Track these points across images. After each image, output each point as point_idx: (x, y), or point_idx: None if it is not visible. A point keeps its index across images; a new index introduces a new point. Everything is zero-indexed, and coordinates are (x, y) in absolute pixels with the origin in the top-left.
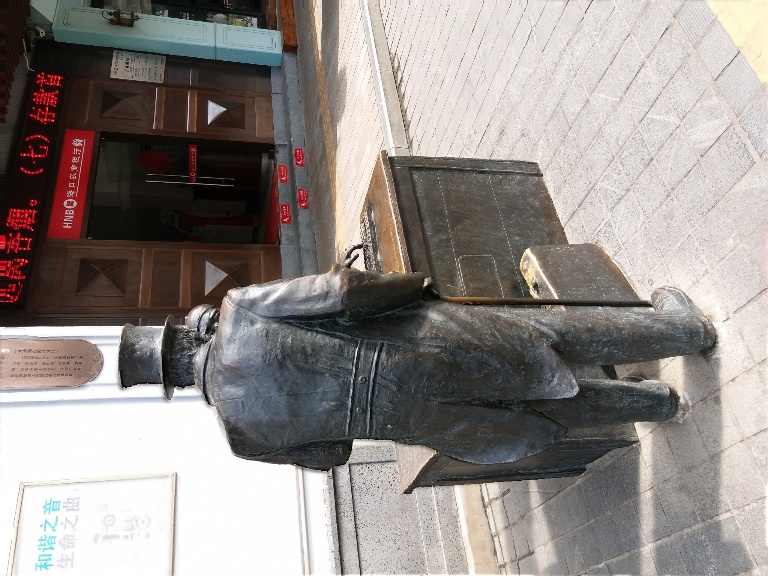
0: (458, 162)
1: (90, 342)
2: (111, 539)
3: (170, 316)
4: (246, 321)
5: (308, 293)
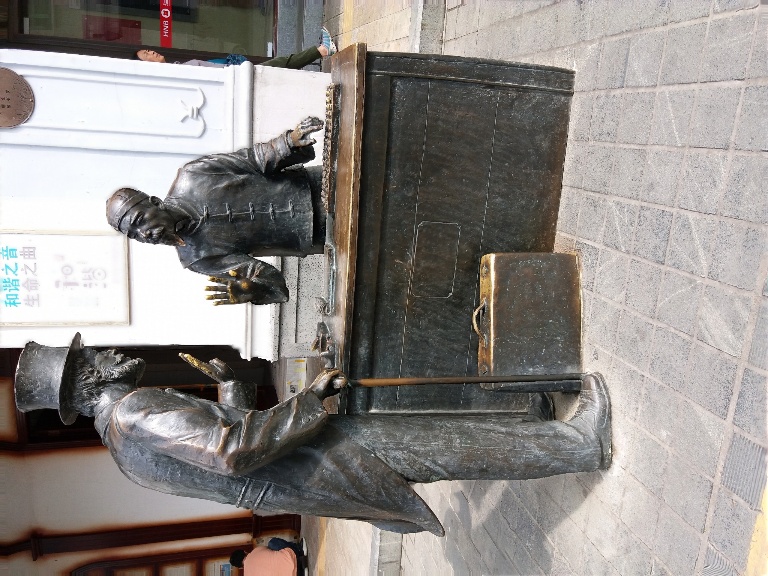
0: (464, 67)
1: (14, 72)
2: (71, 286)
3: (66, 362)
4: (135, 449)
5: (195, 459)
